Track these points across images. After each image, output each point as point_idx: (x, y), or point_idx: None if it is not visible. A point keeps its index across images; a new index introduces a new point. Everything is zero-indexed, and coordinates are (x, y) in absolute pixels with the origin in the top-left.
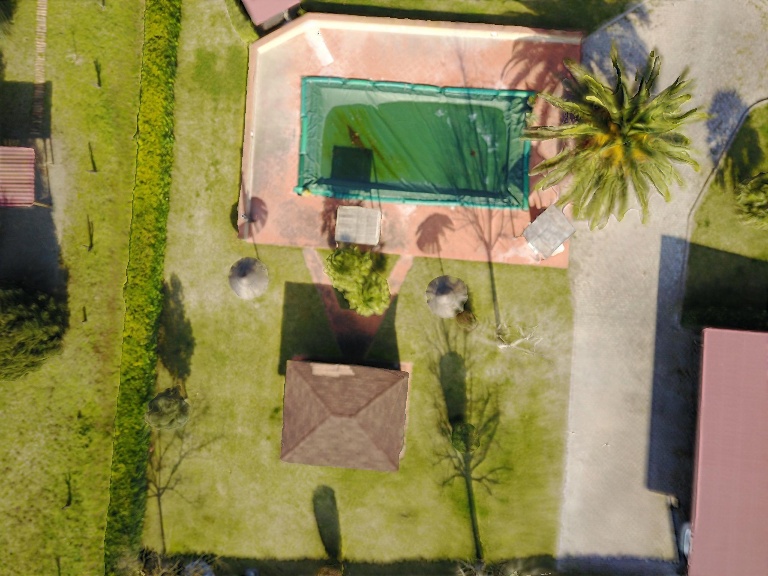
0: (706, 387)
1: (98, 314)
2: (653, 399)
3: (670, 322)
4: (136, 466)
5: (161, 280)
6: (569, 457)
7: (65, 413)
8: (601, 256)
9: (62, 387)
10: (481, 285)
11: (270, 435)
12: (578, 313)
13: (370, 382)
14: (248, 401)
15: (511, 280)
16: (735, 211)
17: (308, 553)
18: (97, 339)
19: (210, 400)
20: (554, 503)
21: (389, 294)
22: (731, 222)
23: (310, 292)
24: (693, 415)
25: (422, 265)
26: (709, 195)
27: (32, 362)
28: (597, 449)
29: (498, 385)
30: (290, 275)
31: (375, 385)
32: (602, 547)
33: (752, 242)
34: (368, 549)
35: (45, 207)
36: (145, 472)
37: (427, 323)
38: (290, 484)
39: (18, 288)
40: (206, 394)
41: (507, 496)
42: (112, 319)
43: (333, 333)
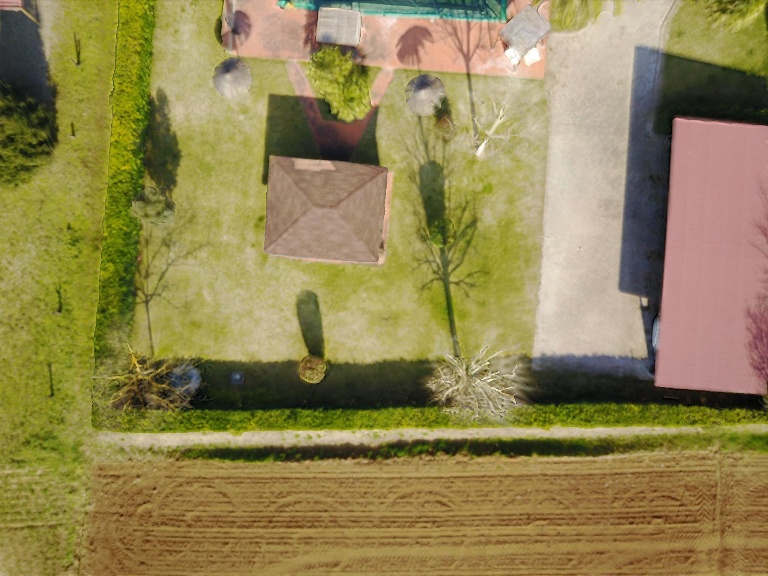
0: (673, 174)
1: (86, 130)
2: (625, 204)
3: (642, 130)
4: (124, 266)
5: (147, 94)
6: (543, 261)
7: (55, 225)
8: (576, 68)
9: (51, 200)
10: (459, 96)
11: (254, 243)
12: (553, 123)
13: (350, 176)
14: (233, 210)
15: (488, 91)
16: (705, 16)
17: (292, 355)
18: (85, 155)
19: (196, 209)
20: (529, 304)
21: (369, 100)
22: (702, 32)
23: (293, 104)
24: (662, 211)
25: (402, 78)
26: (681, 7)
27: (21, 165)
28: (570, 253)
29: (475, 193)
30: (273, 88)
31: (355, 179)
32: (574, 345)
33: (722, 51)
34: (350, 350)
35: (32, 20)
36: (133, 278)
37: (407, 134)
38: (274, 289)
39: (6, 84)
40: (192, 204)
41: (484, 298)
42: (100, 136)
43: (315, 144)
